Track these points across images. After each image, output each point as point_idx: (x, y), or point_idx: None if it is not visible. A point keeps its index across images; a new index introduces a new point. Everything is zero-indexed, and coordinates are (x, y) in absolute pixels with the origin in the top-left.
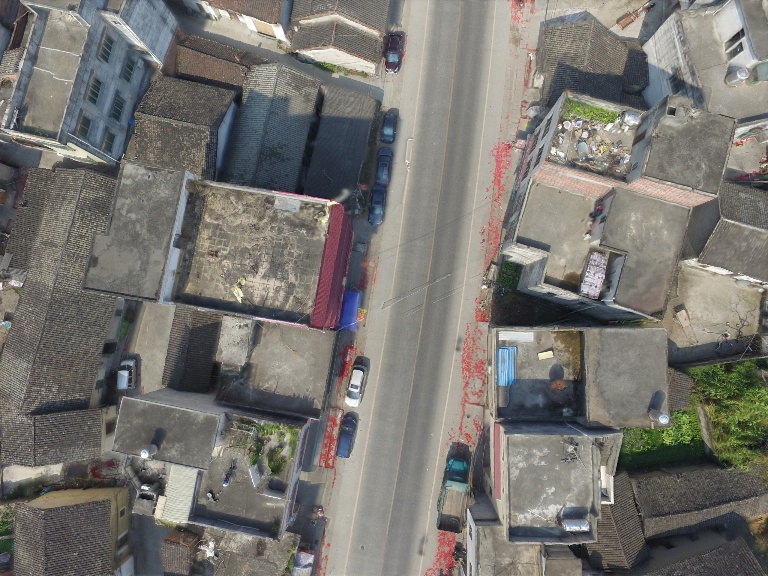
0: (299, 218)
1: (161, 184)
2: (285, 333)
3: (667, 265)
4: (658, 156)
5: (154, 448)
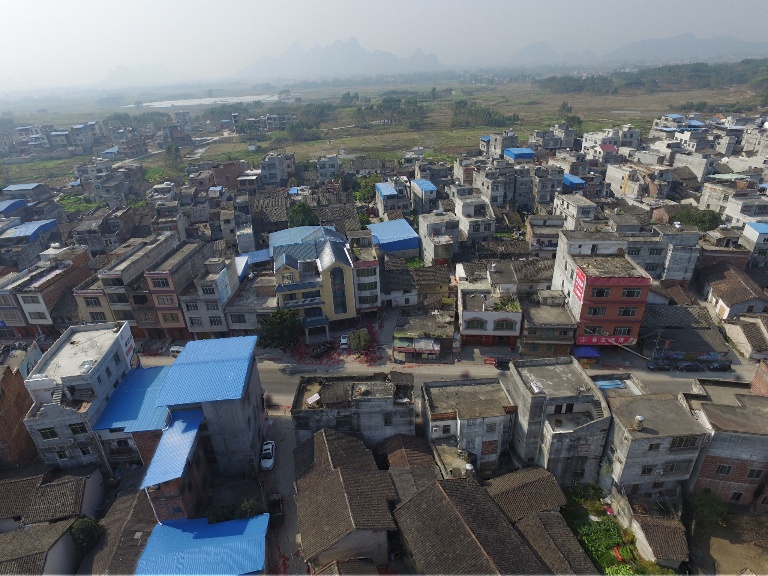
0: (633, 275)
1: (616, 238)
2: (563, 313)
3: (760, 430)
4: None
5: (495, 270)
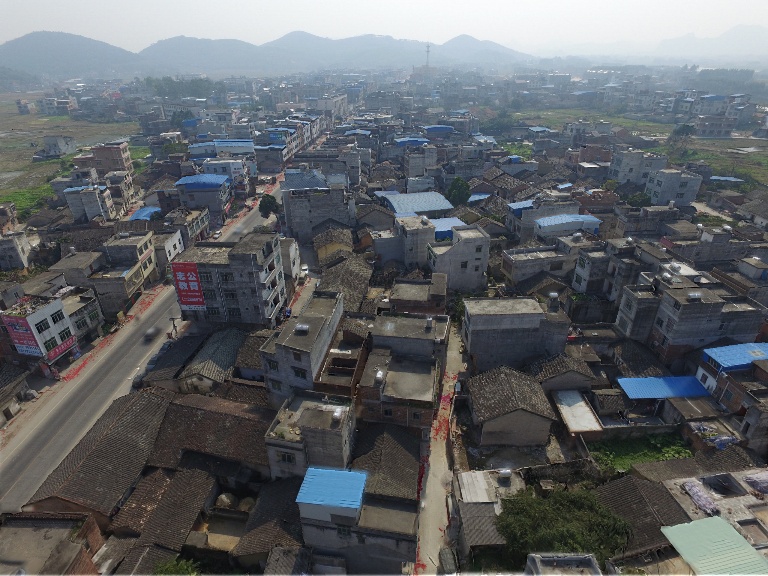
0: None
1: None
2: None
3: None
4: (5, 287)
5: None
